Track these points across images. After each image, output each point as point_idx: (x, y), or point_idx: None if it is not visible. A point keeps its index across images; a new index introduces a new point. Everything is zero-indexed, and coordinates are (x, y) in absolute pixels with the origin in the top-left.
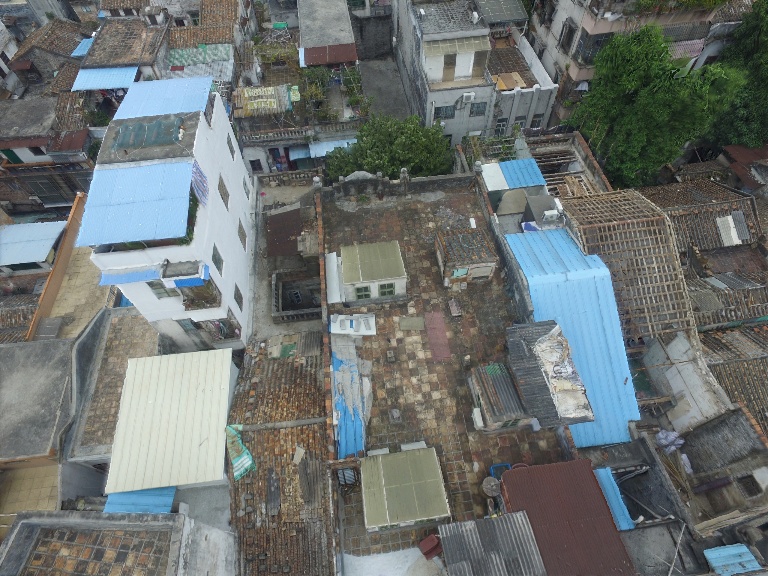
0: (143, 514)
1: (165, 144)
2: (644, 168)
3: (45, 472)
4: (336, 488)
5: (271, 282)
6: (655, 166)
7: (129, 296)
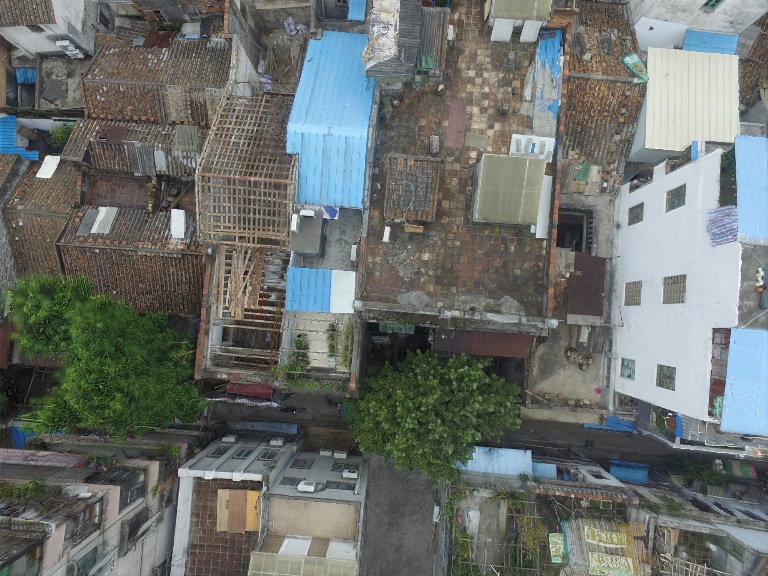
0: None
1: None
2: None
3: None
4: None
5: None
6: None
7: None
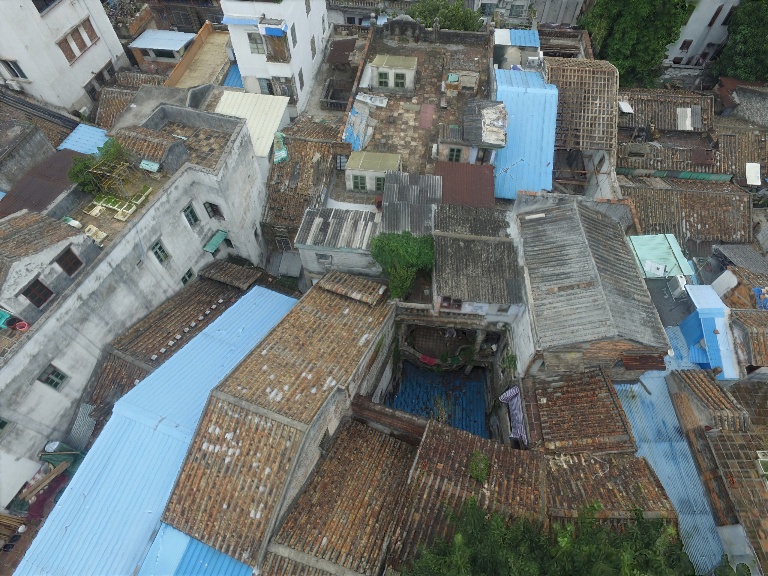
0: None
1: None
2: (634, 67)
3: None
4: None
5: (325, 84)
6: (643, 66)
7: (234, 45)
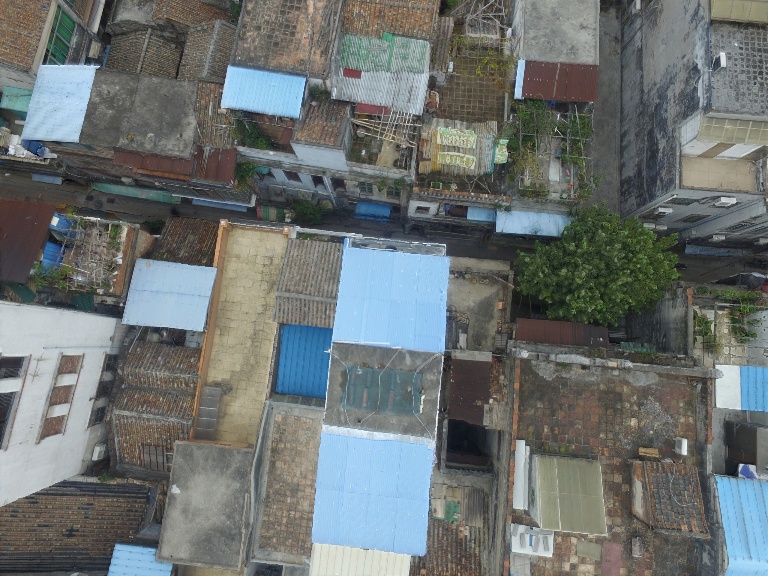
0: None
1: (403, 415)
2: None
3: None
4: None
5: None
6: None
7: None
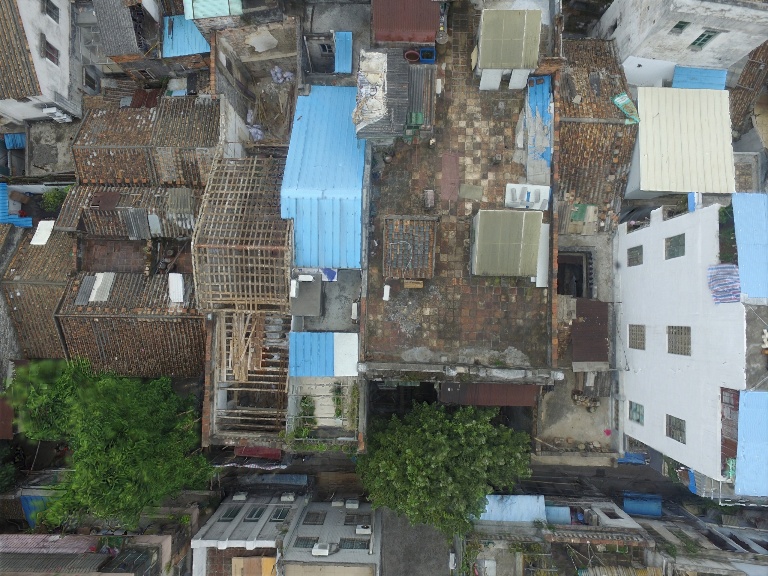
0: (712, 1)
1: None
2: None
3: None
4: None
5: None
6: None
7: None
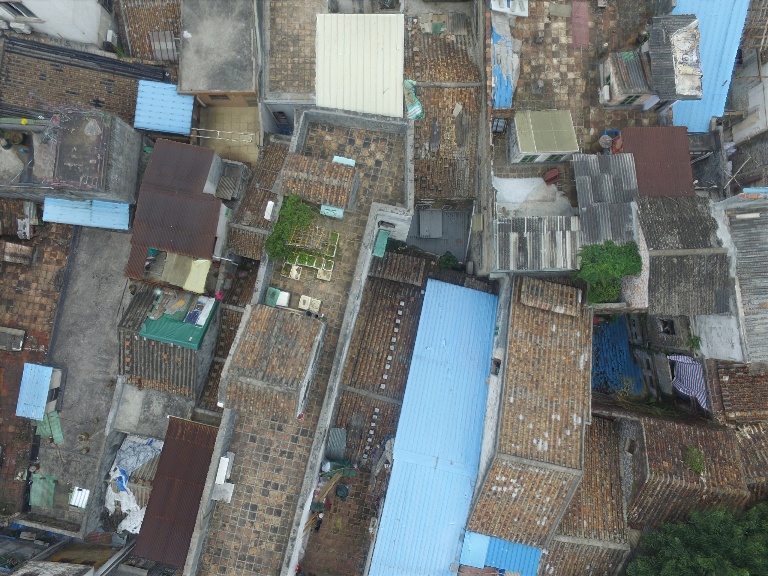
0: None
1: None
2: None
3: (239, 111)
4: (492, 131)
5: None
6: None
7: None
